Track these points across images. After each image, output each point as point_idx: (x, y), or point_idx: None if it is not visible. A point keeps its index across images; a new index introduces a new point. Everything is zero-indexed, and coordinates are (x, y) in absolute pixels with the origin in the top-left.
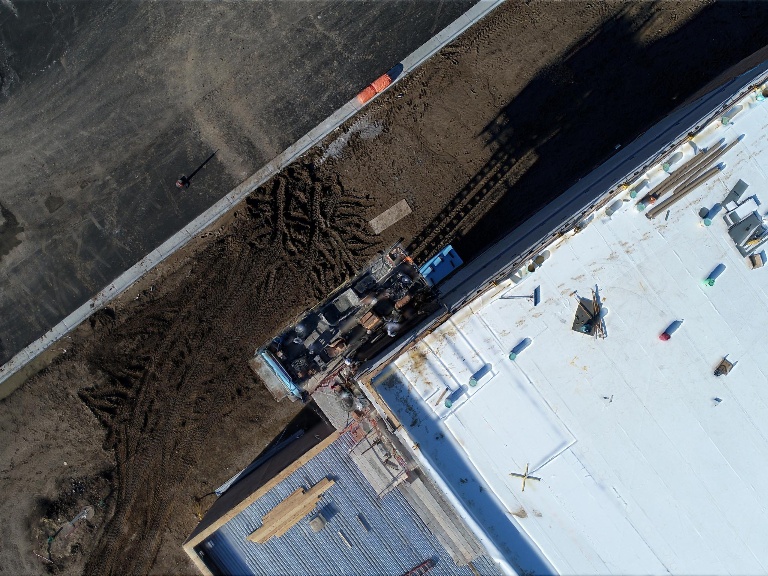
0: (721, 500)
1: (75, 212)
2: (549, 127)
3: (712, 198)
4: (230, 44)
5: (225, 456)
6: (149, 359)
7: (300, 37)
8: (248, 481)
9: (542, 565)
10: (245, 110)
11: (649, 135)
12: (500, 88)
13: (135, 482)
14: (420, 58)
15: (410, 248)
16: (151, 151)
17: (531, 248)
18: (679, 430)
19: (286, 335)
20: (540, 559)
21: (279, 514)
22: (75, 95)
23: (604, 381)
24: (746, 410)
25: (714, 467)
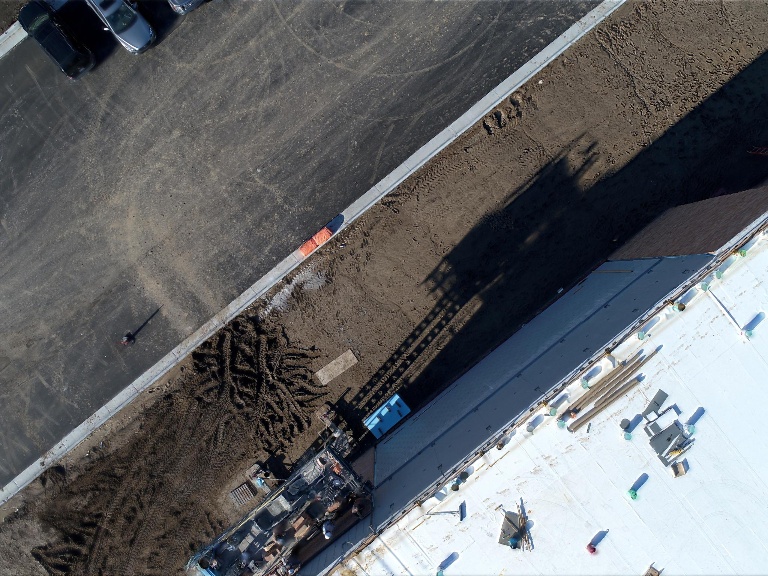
0: None
1: (22, 371)
2: (491, 273)
3: (633, 409)
4: (170, 200)
5: None
6: (101, 516)
7: (240, 191)
8: None
9: None
10: (188, 265)
11: (584, 300)
12: (441, 236)
13: None
14: (360, 209)
15: (357, 397)
16: (96, 308)
17: (454, 468)
18: None
19: (219, 544)
20: None
21: None
22: (17, 256)
23: None
24: None
25: None
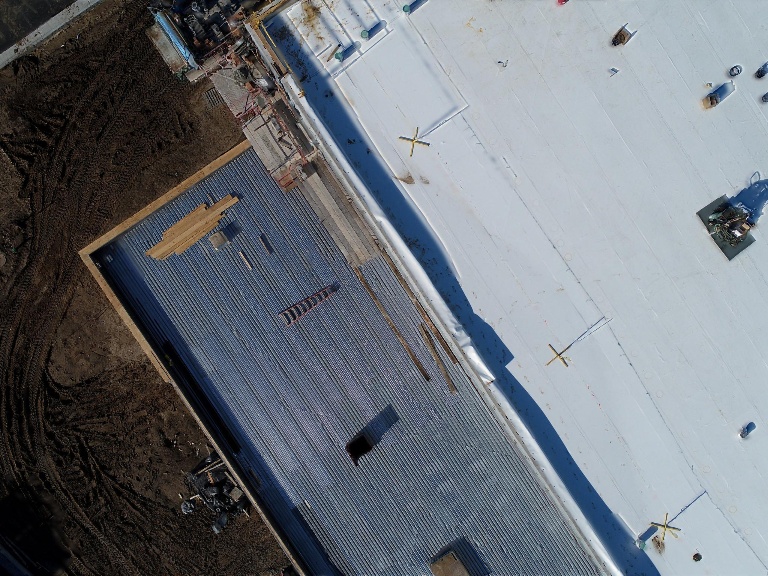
0: (612, 176)
1: None
2: None
3: None
4: None
5: None
6: (71, 108)
7: None
8: None
9: (426, 234)
10: None
11: None
12: None
13: (49, 233)
14: None
15: None
16: None
17: None
18: (573, 100)
19: None
20: (424, 227)
21: (180, 229)
22: None
23: (500, 45)
24: (643, 83)
25: (607, 141)
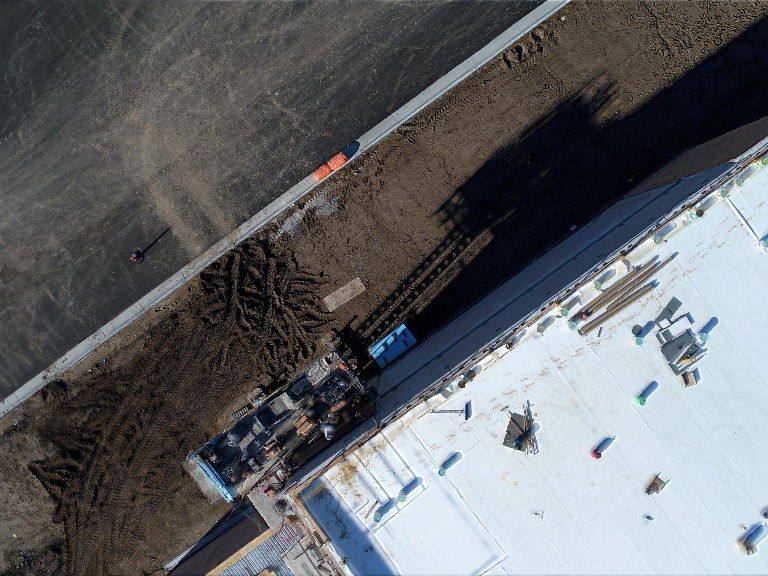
0: None
1: (29, 283)
2: (505, 207)
3: (645, 315)
4: (187, 119)
5: (175, 532)
6: (100, 433)
7: (257, 113)
8: (194, 562)
9: None
10: (201, 185)
11: (598, 228)
12: (456, 167)
13: (84, 556)
14: (376, 136)
15: (364, 326)
16: (106, 224)
17: (462, 364)
18: (610, 548)
19: (220, 439)
20: None
21: None
22: (31, 167)
23: (535, 497)
24: (678, 529)
25: None
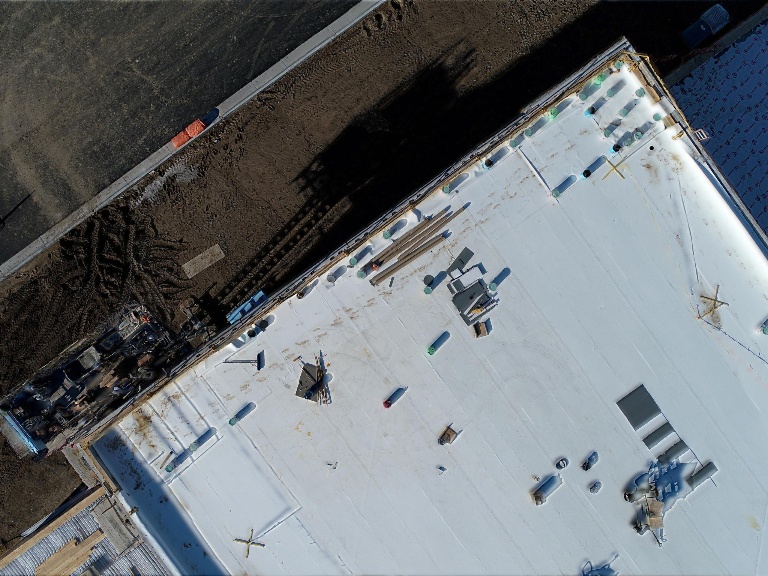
0: (446, 570)
1: None
2: (364, 174)
3: (437, 265)
4: (48, 86)
5: (33, 499)
6: None
7: (117, 80)
8: None
9: None
10: (62, 152)
11: None
12: (315, 135)
13: None
14: (236, 103)
15: (223, 293)
16: None
17: (251, 313)
18: (404, 498)
19: (26, 392)
20: None
21: (51, 566)
22: None
23: (328, 447)
24: (471, 480)
25: (439, 537)
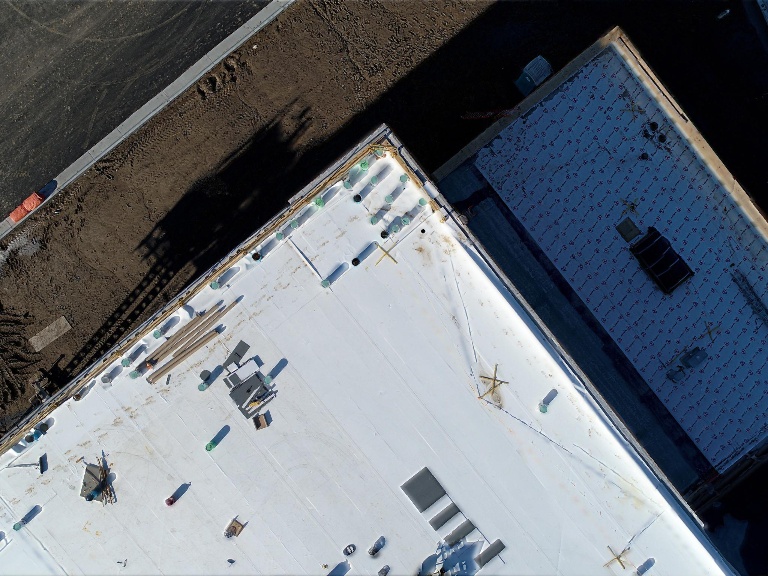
0: None
1: None
2: (206, 239)
3: (213, 360)
4: None
5: None
6: None
7: None
8: None
9: None
10: None
11: None
12: (155, 202)
13: None
14: (73, 174)
15: (72, 364)
16: None
17: (27, 419)
18: None
19: None
20: None
21: None
22: None
23: (117, 546)
24: (260, 570)
25: None
